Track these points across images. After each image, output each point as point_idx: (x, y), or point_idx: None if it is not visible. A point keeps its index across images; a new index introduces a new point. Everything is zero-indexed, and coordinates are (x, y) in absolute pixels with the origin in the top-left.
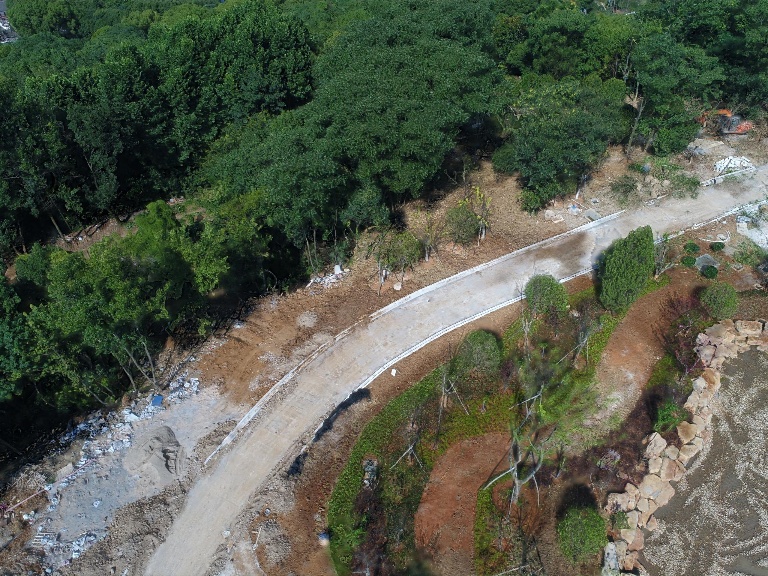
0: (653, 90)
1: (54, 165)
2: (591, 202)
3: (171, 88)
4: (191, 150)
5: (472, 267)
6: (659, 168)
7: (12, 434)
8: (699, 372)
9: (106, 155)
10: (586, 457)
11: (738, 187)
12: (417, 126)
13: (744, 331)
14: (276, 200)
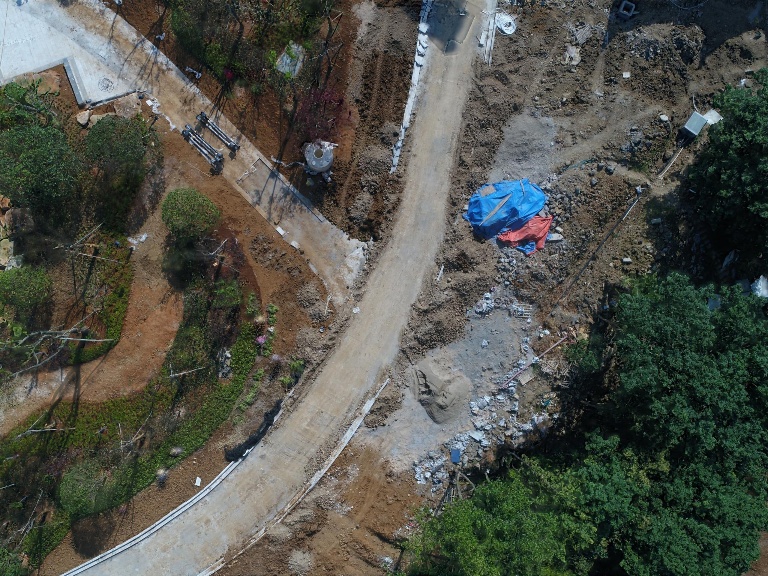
0: None
1: None
2: None
3: None
4: None
5: None
6: None
7: (603, 427)
8: None
9: None
10: None
11: None
12: None
13: None
14: None
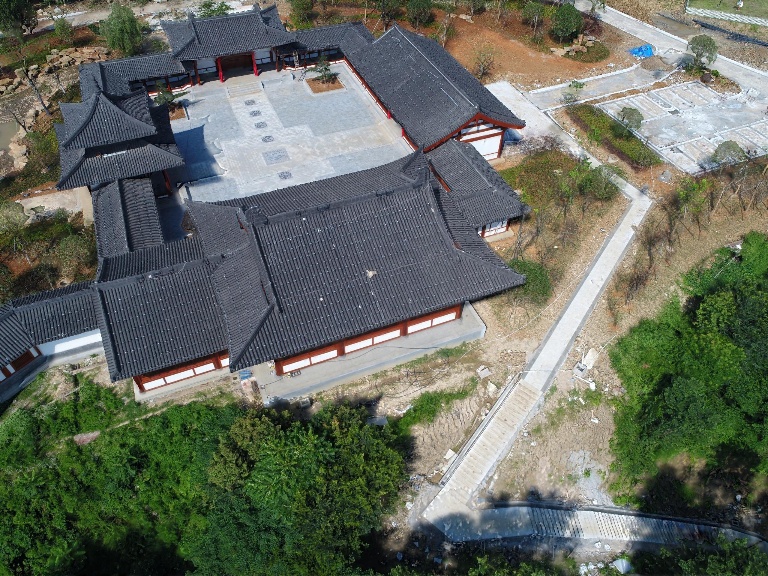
0: None
1: None
2: (76, 9)
3: None
4: None
5: None
6: None
7: None
8: (40, 64)
9: None
10: None
11: (175, 3)
12: None
13: (84, 50)
14: None
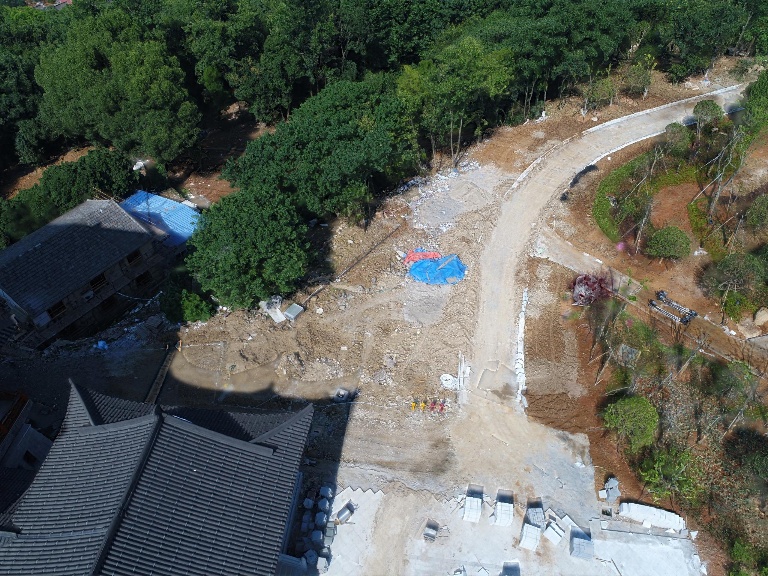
0: (760, 2)
1: (328, 46)
2: (715, 80)
3: (395, 2)
4: (399, 53)
5: (643, 110)
6: (761, 62)
7: None
8: None
9: (362, 42)
10: (749, 196)
11: None
12: (614, 6)
13: None
14: (525, 49)
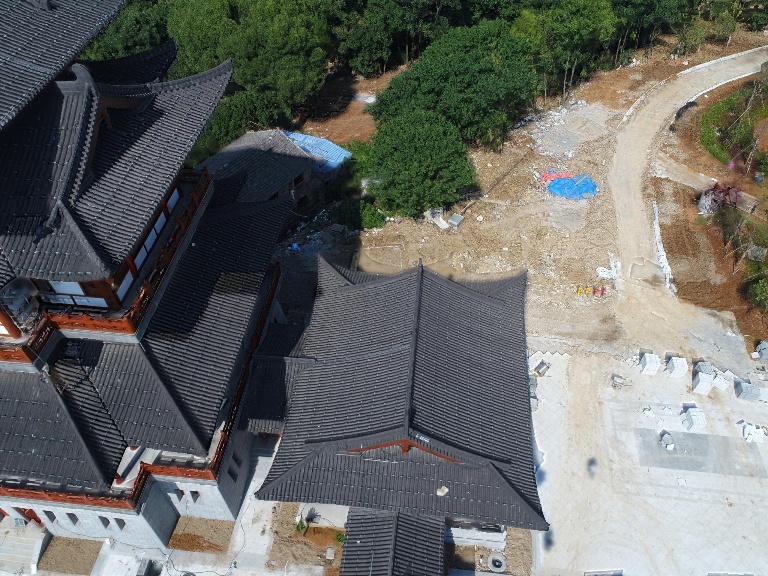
0: None
1: (428, 1)
2: None
3: None
4: (482, 10)
5: (729, 55)
6: None
7: None
8: None
9: None
10: None
11: None
12: None
13: None
14: None
